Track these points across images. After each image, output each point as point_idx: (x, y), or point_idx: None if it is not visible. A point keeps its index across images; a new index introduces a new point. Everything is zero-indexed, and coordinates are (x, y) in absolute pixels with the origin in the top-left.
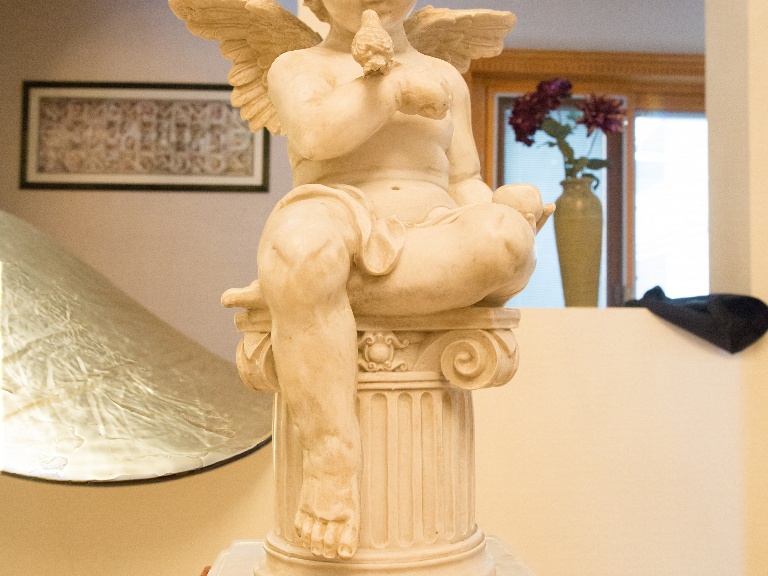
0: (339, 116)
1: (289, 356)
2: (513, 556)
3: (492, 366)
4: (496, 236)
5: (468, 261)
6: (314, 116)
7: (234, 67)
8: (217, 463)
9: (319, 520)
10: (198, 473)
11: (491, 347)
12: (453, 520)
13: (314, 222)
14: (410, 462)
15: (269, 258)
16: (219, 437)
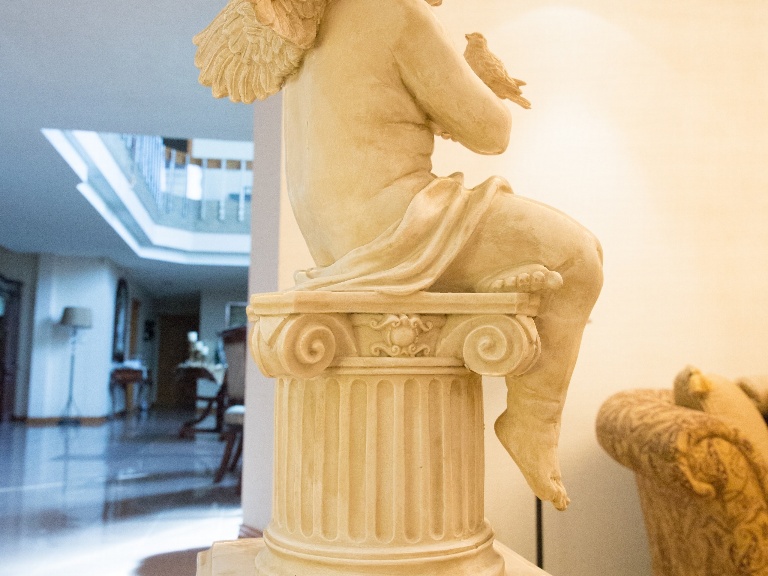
0: None
1: None
2: None
3: None
4: None
5: None
6: None
7: None
8: None
9: None
10: None
11: None
12: None
13: None
14: None
15: None
16: None
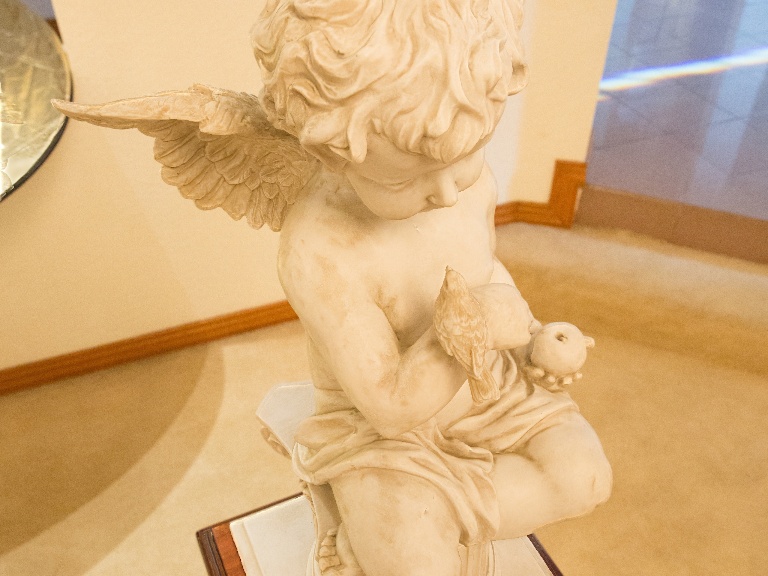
0: (429, 413)
1: None
2: None
3: None
4: (590, 505)
5: None
6: (400, 417)
7: (162, 144)
8: (27, 176)
9: None
10: (10, 192)
11: None
12: (485, 570)
13: (440, 570)
14: (465, 574)
15: None
16: (6, 127)
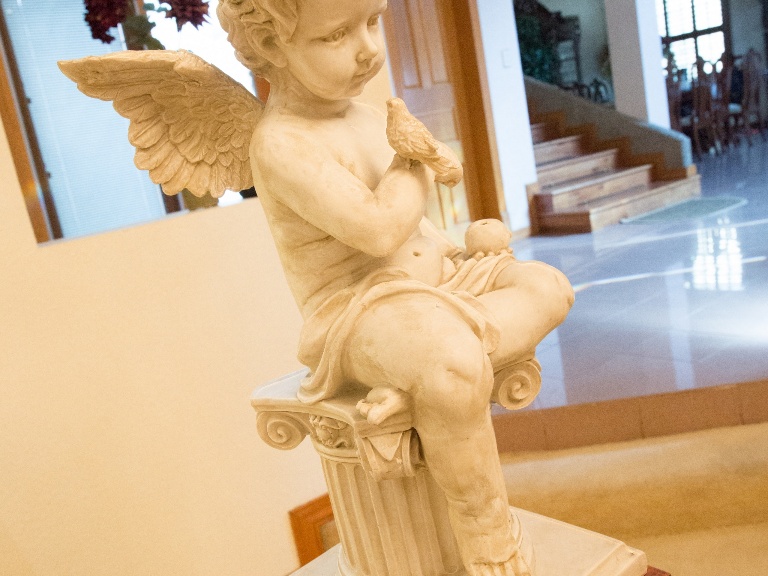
0: (411, 215)
1: (464, 453)
2: None
3: (537, 386)
4: (562, 296)
5: (546, 321)
6: (389, 219)
7: (136, 126)
8: None
9: (497, 565)
10: None
11: (535, 372)
12: None
13: (467, 335)
14: None
15: (447, 380)
16: None
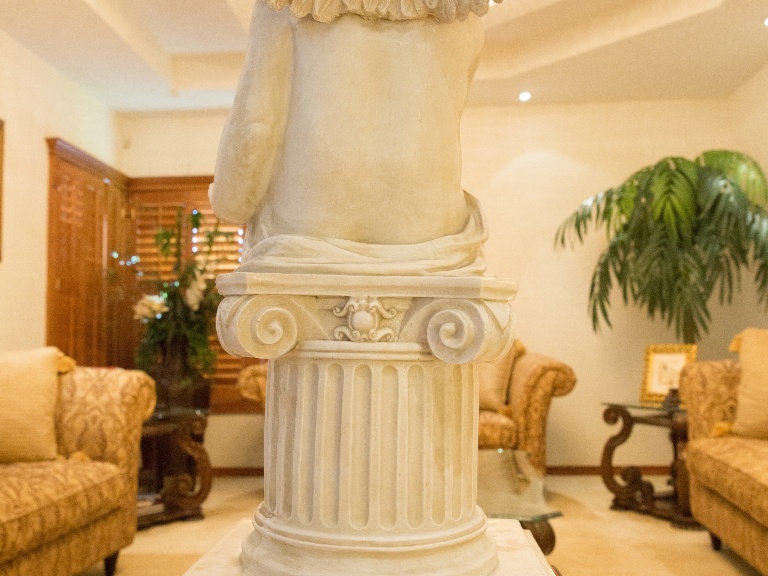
0: None
1: None
2: (195, 567)
3: None
4: None
5: None
6: None
7: None
8: None
9: None
10: None
11: None
12: None
13: None
14: None
15: None
16: None
